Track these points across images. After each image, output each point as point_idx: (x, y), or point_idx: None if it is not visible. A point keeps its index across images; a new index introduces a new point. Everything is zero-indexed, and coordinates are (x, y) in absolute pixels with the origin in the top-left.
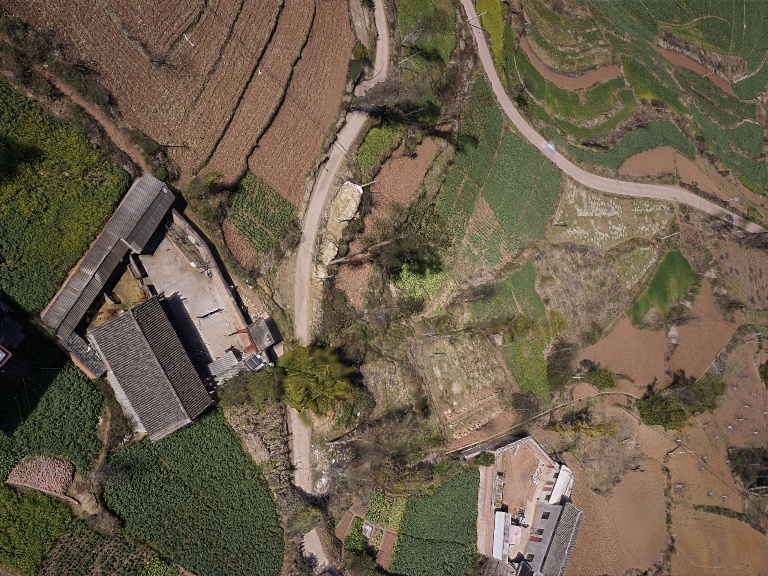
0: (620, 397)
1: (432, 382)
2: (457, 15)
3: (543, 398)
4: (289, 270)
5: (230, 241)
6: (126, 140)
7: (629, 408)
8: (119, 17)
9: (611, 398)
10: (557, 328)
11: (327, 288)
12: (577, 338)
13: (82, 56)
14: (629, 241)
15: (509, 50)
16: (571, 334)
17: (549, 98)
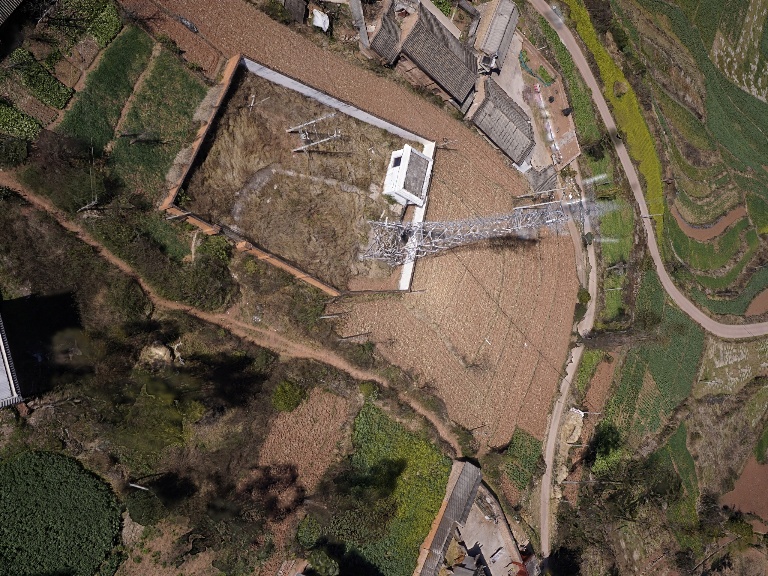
0: (752, 537)
1: (620, 553)
2: (633, 213)
3: (698, 552)
4: (537, 496)
5: (505, 487)
6: (448, 431)
7: (760, 547)
8: (451, 343)
9: (746, 539)
10: (704, 481)
11: (561, 503)
12: (718, 487)
13: (427, 379)
14: (755, 382)
15: (665, 223)
16: (714, 484)
17: (692, 256)
